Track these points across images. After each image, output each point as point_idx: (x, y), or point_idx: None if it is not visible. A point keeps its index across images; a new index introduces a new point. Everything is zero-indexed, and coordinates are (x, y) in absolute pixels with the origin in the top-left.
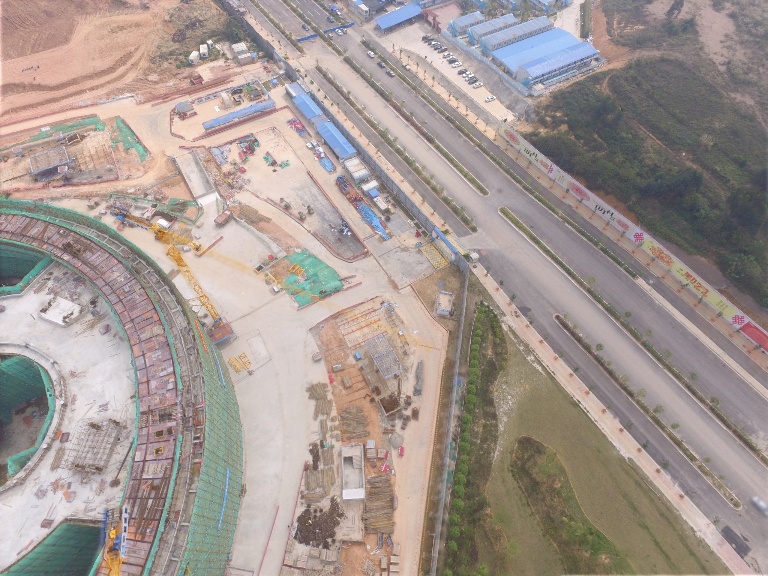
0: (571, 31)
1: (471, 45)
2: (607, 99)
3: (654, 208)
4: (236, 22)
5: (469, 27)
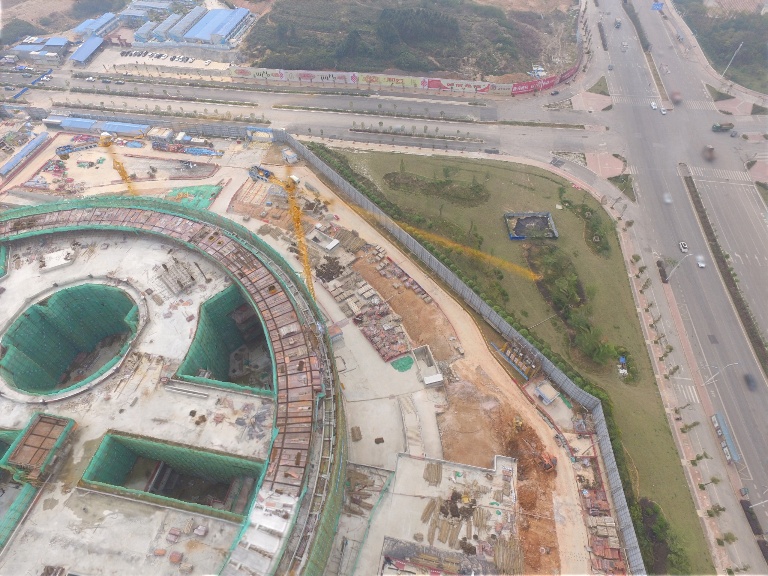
0: (222, 8)
1: (163, 41)
2: (279, 22)
3: (349, 61)
4: None
5: (152, 31)
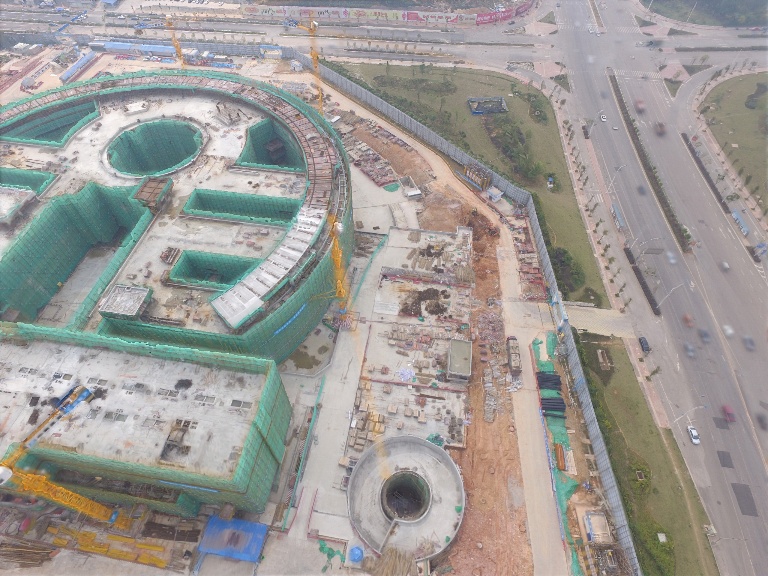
0: None
1: None
2: None
3: None
4: (1, 32)
5: None
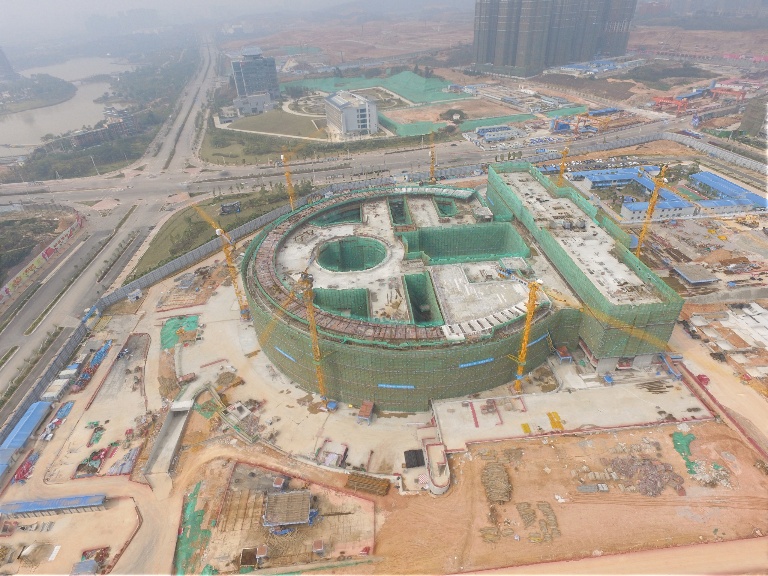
0: None
1: None
2: None
3: None
4: None
5: None
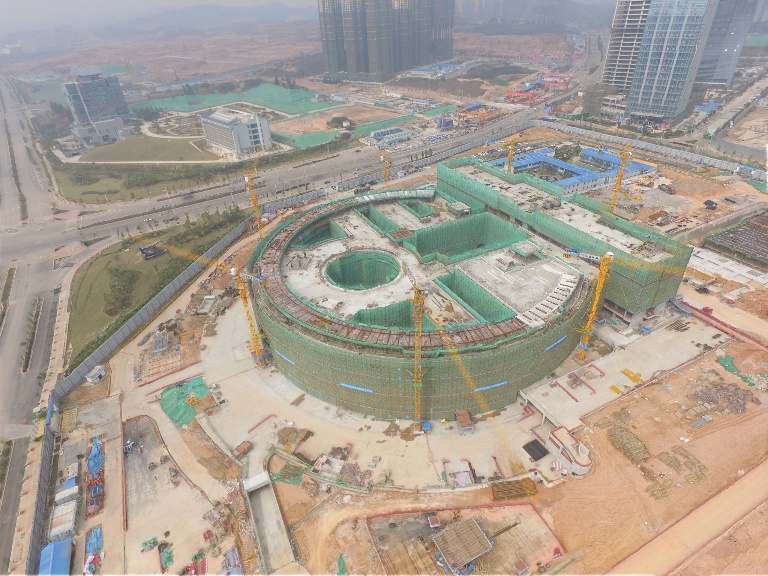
0: None
1: None
2: None
3: None
4: None
5: None
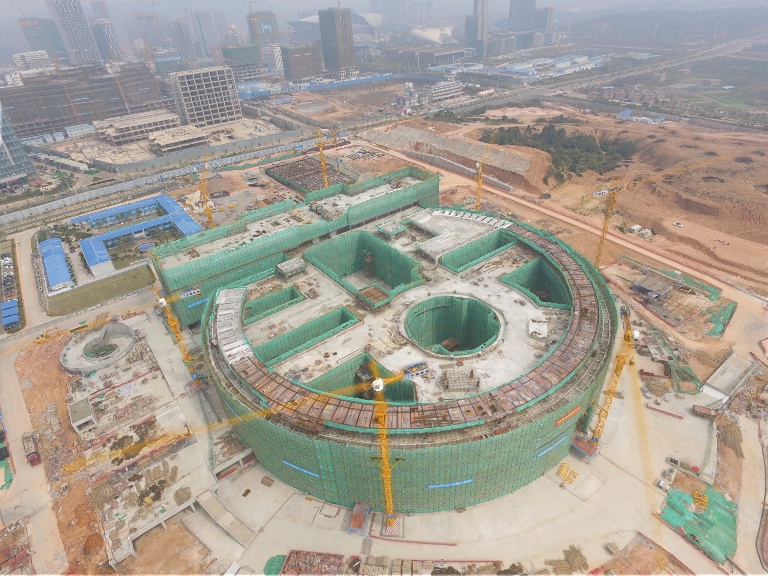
0: None
1: None
2: None
3: None
4: None
5: None
